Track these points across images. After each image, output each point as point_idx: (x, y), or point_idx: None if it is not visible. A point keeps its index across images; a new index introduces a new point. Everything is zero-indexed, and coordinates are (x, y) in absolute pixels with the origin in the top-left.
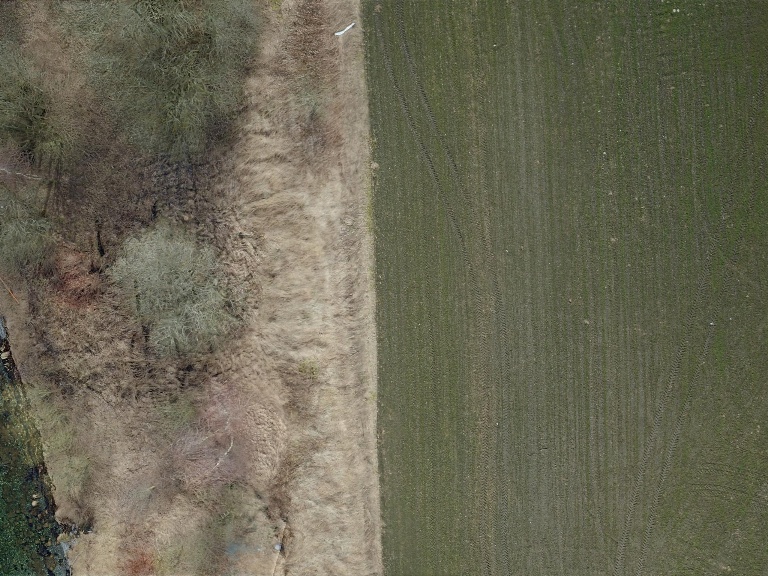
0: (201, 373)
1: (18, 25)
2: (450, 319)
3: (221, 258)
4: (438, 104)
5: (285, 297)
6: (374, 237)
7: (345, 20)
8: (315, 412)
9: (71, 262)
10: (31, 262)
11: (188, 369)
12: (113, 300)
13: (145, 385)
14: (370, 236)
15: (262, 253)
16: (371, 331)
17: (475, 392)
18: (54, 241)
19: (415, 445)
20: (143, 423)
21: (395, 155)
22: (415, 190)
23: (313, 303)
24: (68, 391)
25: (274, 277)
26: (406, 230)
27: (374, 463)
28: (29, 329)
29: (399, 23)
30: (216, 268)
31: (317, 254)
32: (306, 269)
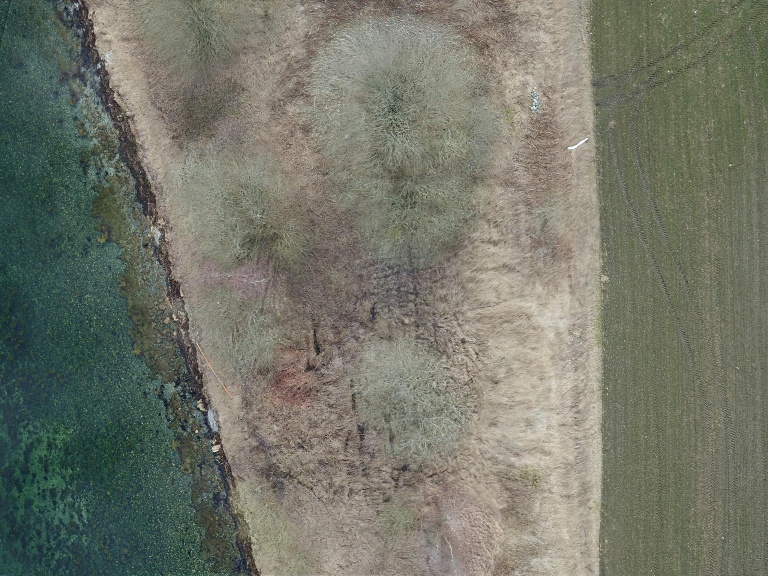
0: (416, 474)
1: (239, 125)
2: (677, 433)
3: (441, 362)
4: (671, 220)
5: (508, 404)
6: (602, 349)
7: (578, 135)
8: (536, 519)
9: (288, 360)
10: (246, 358)
11: (403, 469)
12: (328, 398)
13: (359, 483)
14: (598, 348)
15: (485, 359)
16: (597, 441)
17: (701, 506)
18: (271, 339)
19: (638, 555)
20: (355, 520)
21: (626, 269)
22: (645, 304)
23: (537, 411)
24: (279, 485)
25: (497, 384)
26: (635, 343)
27: (596, 571)
28: (241, 423)
29: (633, 139)
30: (435, 371)
31: (544, 364)
32: (532, 378)
